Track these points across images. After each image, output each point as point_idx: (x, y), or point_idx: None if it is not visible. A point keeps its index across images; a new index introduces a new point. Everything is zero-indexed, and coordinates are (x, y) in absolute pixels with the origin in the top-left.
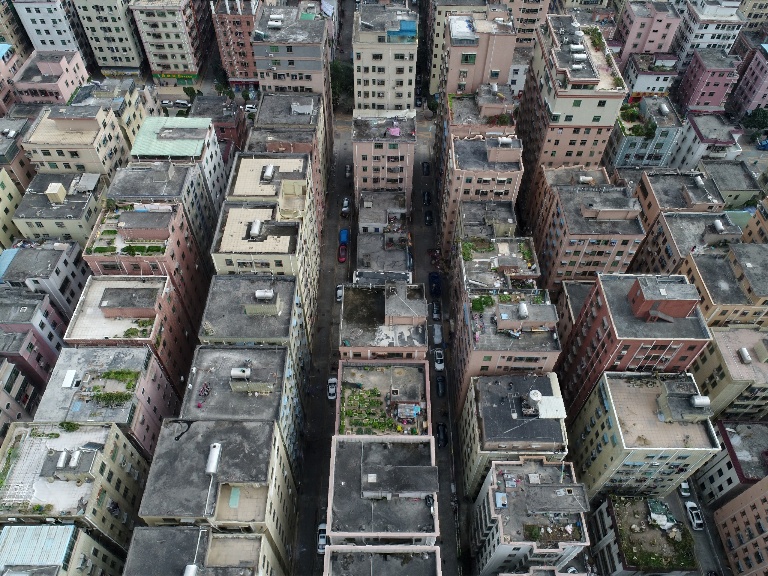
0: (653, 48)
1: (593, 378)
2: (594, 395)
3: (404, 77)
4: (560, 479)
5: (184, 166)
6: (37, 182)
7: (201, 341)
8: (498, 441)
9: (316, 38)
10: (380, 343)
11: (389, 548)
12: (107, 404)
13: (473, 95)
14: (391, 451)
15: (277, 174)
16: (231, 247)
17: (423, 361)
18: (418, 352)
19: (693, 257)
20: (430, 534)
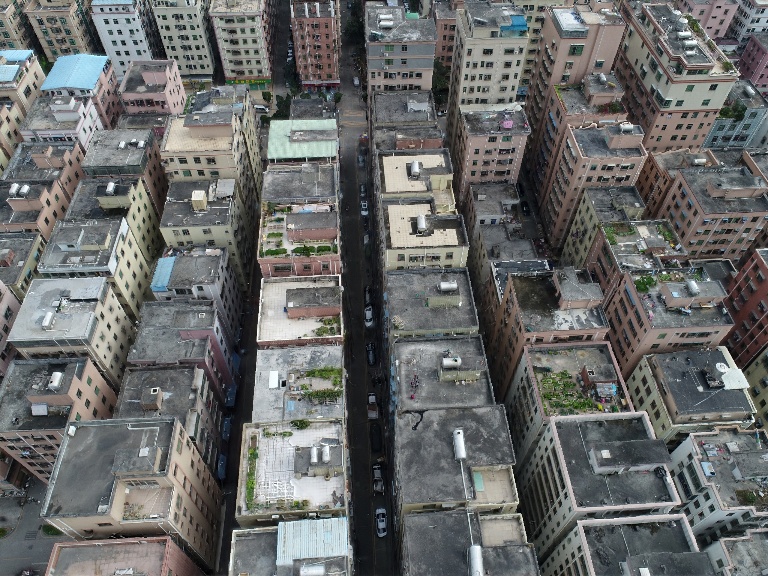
0: (710, 34)
1: (754, 350)
2: (755, 366)
3: (511, 71)
4: (758, 446)
5: (322, 167)
6: (174, 190)
7: (391, 335)
8: (691, 414)
9: (429, 36)
10: (561, 327)
11: (638, 519)
12: (320, 401)
13: (578, 85)
14: (607, 428)
15: (422, 170)
16: (402, 242)
17: (604, 342)
18: (599, 334)
19: None
20: (672, 503)
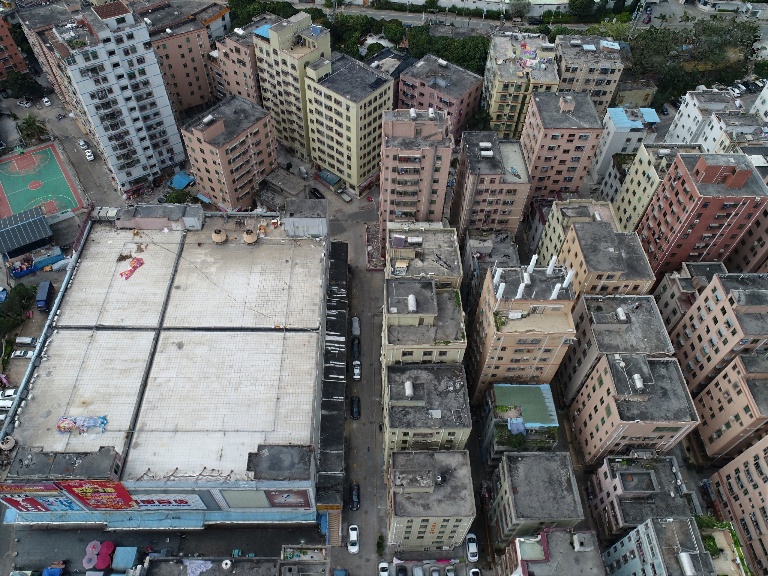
0: None
1: None
2: None
3: None
4: None
5: None
6: None
7: None
8: None
9: None
10: None
11: None
12: None
13: None
14: None
15: None
16: None
17: None
18: None
19: None
20: None
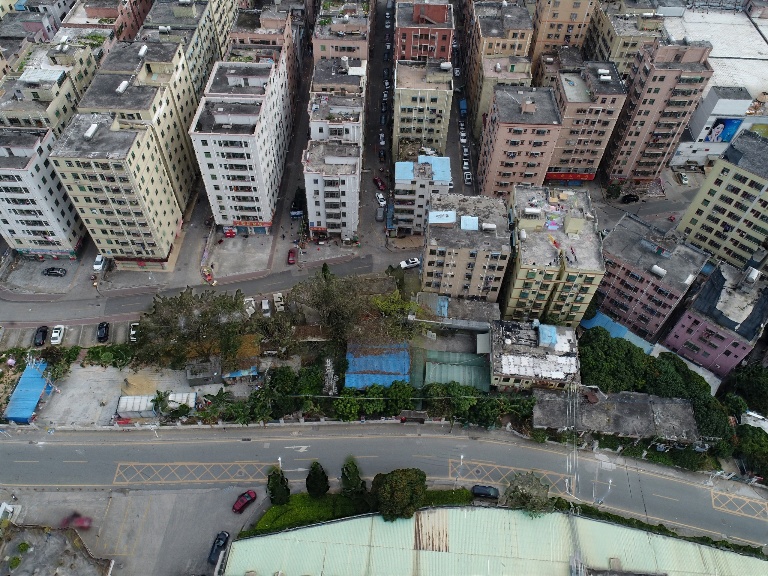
0: None
1: None
2: None
3: None
4: None
5: None
6: None
7: None
8: (320, 83)
9: None
10: None
11: (237, 98)
12: None
13: None
14: None
15: None
16: None
17: (281, 45)
18: (279, 40)
19: (480, 18)
20: (261, 95)
